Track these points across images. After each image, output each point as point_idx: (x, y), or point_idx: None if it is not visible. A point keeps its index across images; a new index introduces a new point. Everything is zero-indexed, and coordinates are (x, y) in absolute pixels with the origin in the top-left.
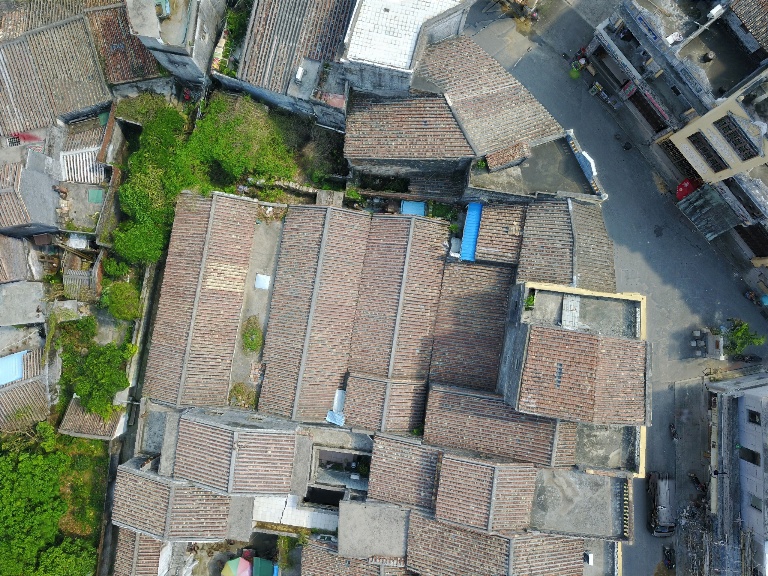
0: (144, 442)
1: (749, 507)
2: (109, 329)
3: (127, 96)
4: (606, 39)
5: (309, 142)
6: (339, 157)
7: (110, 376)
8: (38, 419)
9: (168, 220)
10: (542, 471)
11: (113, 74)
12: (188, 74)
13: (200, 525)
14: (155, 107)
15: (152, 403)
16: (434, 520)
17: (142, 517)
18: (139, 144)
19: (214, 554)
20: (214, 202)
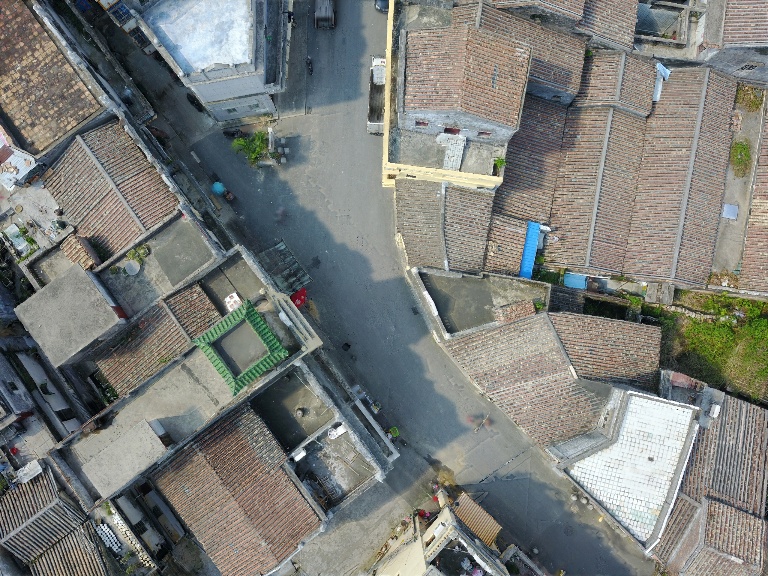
0: None
1: None
2: None
3: None
4: (390, 443)
5: None
6: None
7: None
8: None
9: None
10: None
11: None
12: None
13: None
14: None
15: None
16: None
17: None
18: None
19: None
20: None
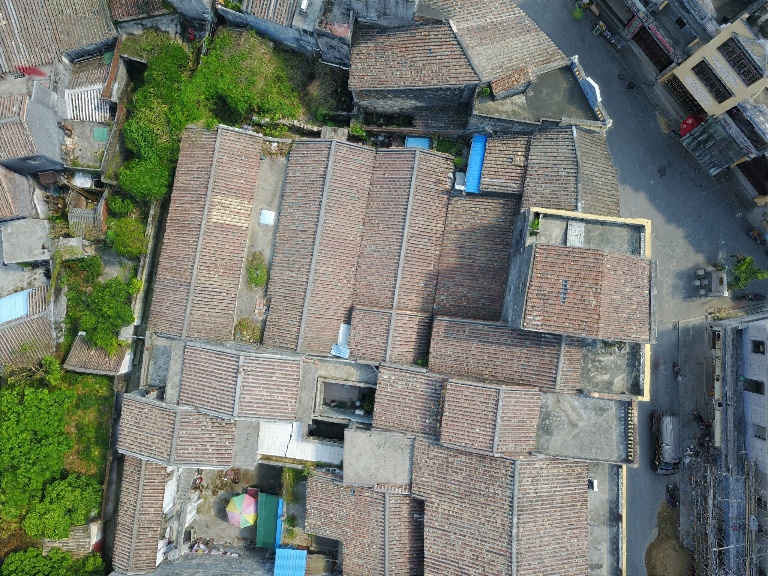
0: (149, 376)
1: (753, 437)
2: (114, 269)
3: (132, 34)
4: None
5: (313, 80)
6: (343, 96)
7: (115, 308)
8: (43, 356)
9: (173, 156)
10: (547, 396)
11: (118, 10)
12: (193, 10)
13: (206, 451)
14: (160, 44)
15: (157, 337)
16: (439, 446)
17: (148, 444)
18: (144, 83)
19: (219, 493)
20: (219, 135)
